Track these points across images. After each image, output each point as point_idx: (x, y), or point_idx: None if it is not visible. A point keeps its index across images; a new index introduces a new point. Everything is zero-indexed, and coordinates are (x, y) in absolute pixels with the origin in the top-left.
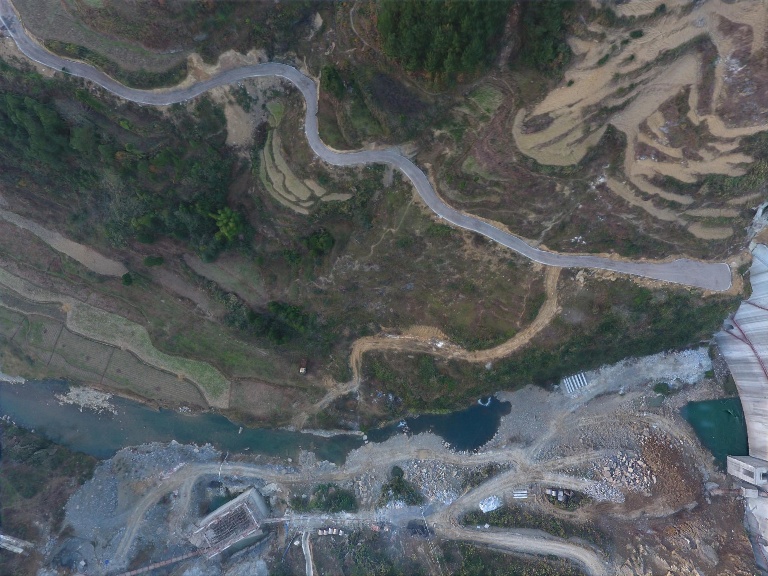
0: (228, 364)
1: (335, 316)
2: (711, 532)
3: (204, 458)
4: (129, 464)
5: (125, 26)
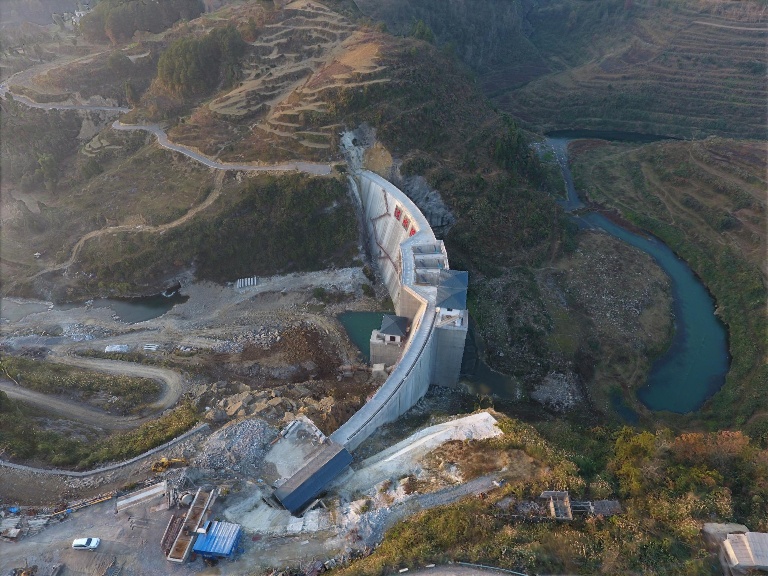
0: None
1: (78, 209)
2: (318, 383)
3: None
4: None
5: None
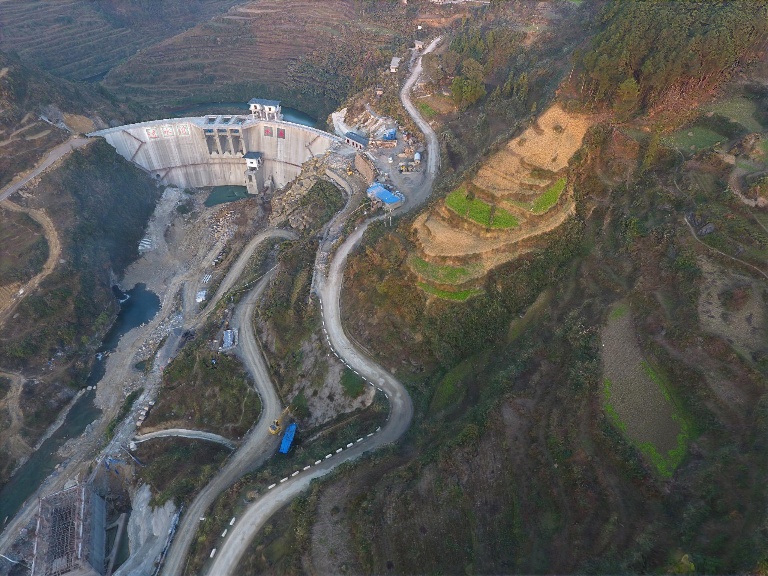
0: None
1: None
2: None
3: None
4: None
5: None
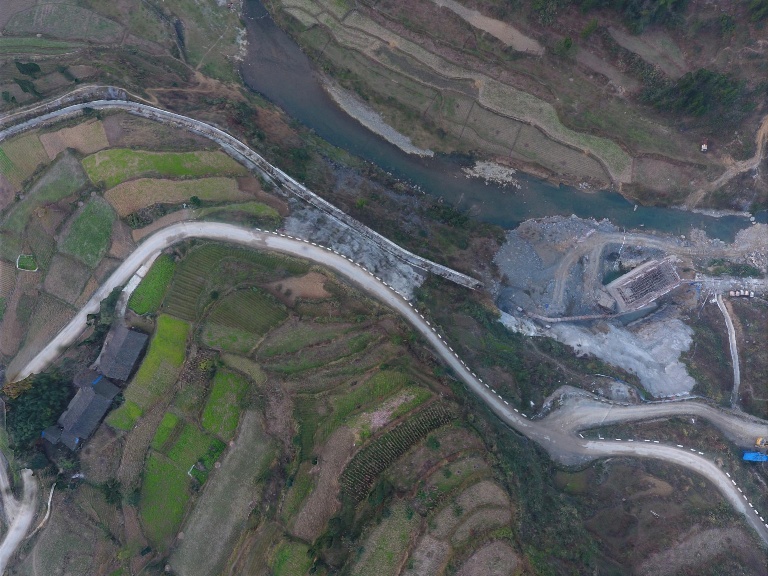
0: (633, 140)
1: (766, 81)
2: None
3: (606, 230)
4: (540, 231)
5: None
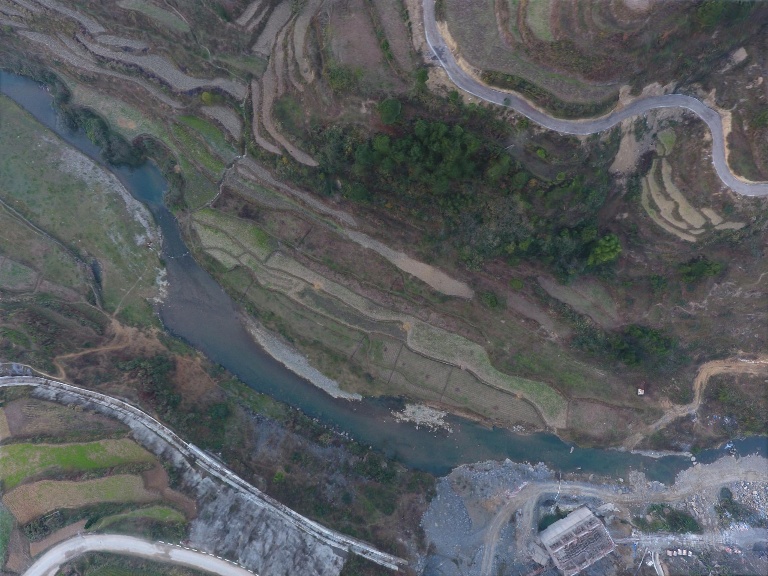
0: (567, 385)
1: (699, 341)
2: None
3: (541, 477)
4: (472, 482)
5: (576, 60)
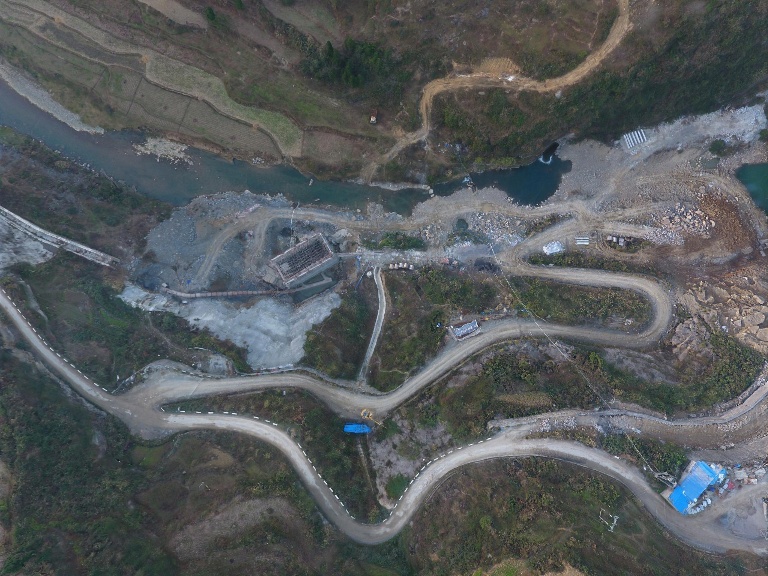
0: (301, 113)
1: (410, 49)
2: (767, 272)
3: (277, 205)
4: (205, 206)
5: None
